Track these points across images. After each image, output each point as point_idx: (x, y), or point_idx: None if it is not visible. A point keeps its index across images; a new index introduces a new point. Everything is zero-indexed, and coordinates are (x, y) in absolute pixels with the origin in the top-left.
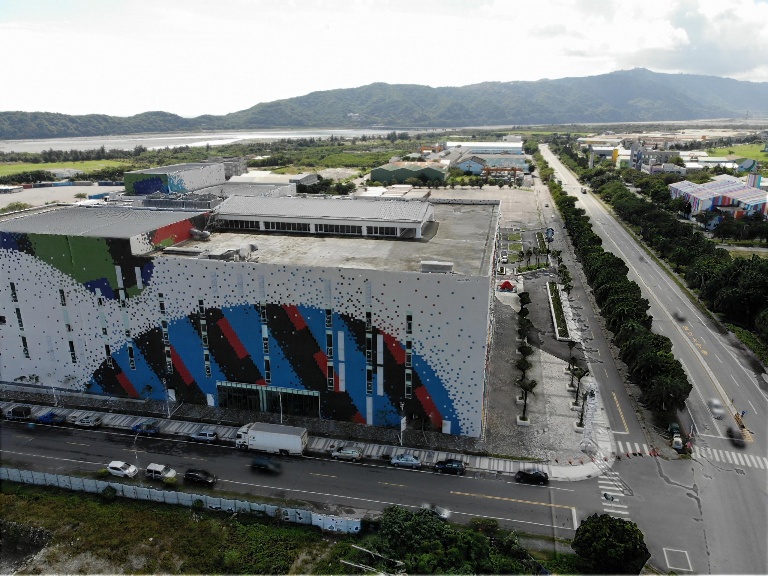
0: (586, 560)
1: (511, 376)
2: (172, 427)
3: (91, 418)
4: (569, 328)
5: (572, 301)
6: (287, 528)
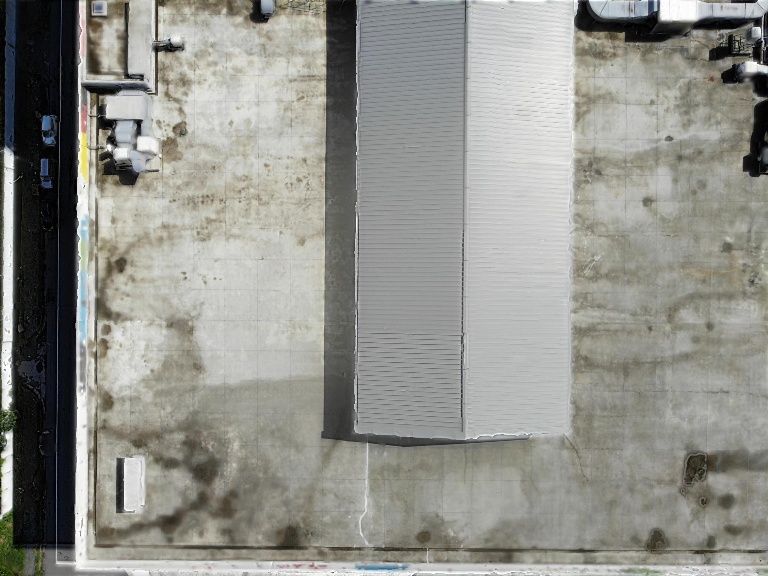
0: (17, 567)
1: None
2: None
3: None
4: None
5: None
6: (1, 323)
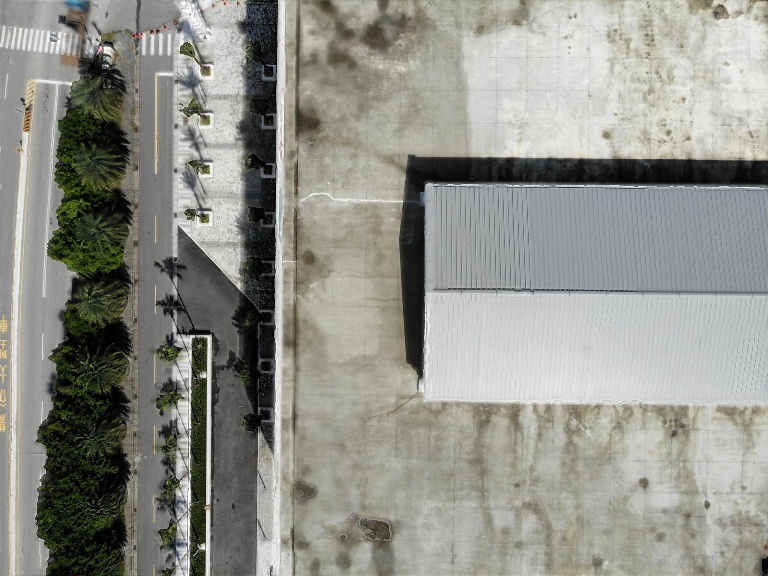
0: None
1: None
2: None
3: None
4: None
5: None
6: None
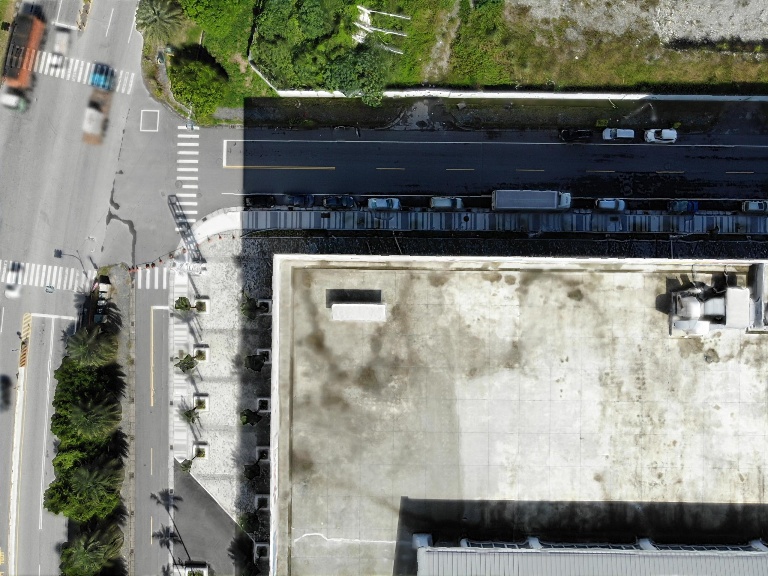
0: None
1: None
2: (658, 221)
3: (756, 205)
4: None
5: None
6: (468, 86)
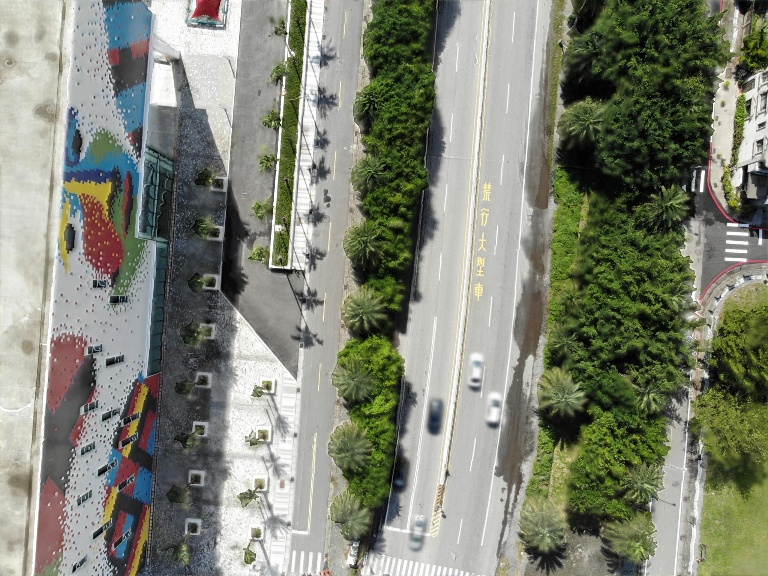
0: None
1: (188, 410)
2: None
3: None
4: (296, 214)
5: (326, 64)
6: None
